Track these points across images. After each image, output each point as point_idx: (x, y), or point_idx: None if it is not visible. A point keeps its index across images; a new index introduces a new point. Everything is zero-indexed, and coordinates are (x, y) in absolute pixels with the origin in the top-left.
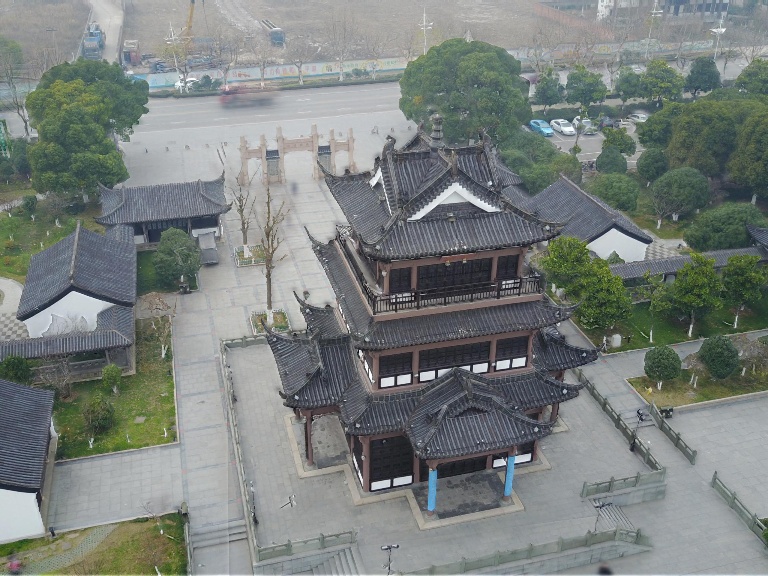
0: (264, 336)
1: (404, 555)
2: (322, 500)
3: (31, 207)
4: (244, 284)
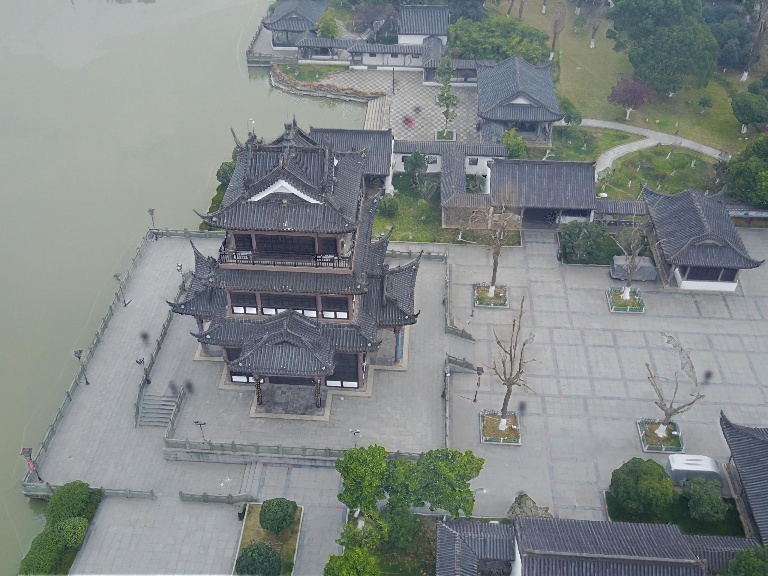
0: None
1: None
2: None
3: None
4: (570, 291)
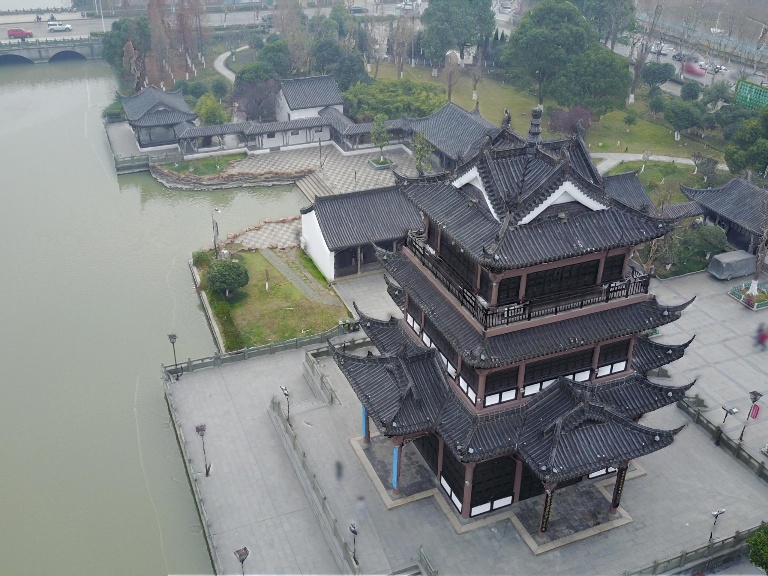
0: None
1: (320, 432)
2: None
3: (707, 168)
4: (697, 303)
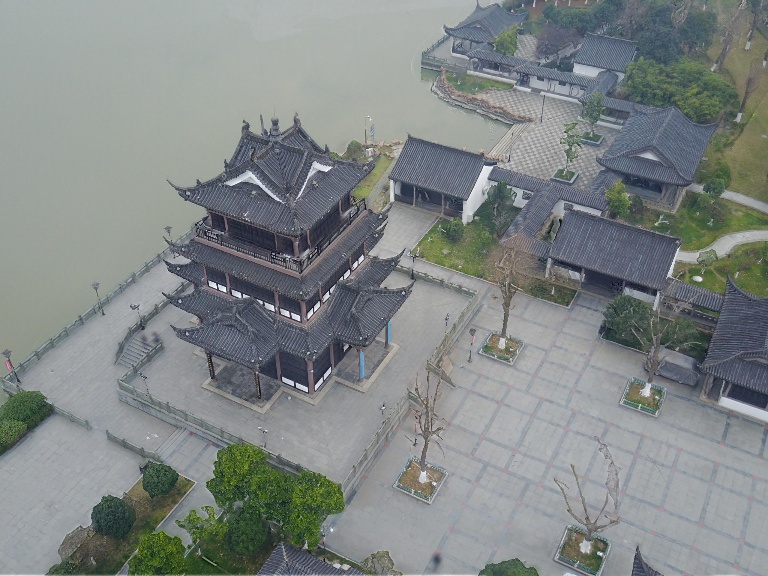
0: (464, 312)
1: None
2: None
3: None
4: (590, 368)
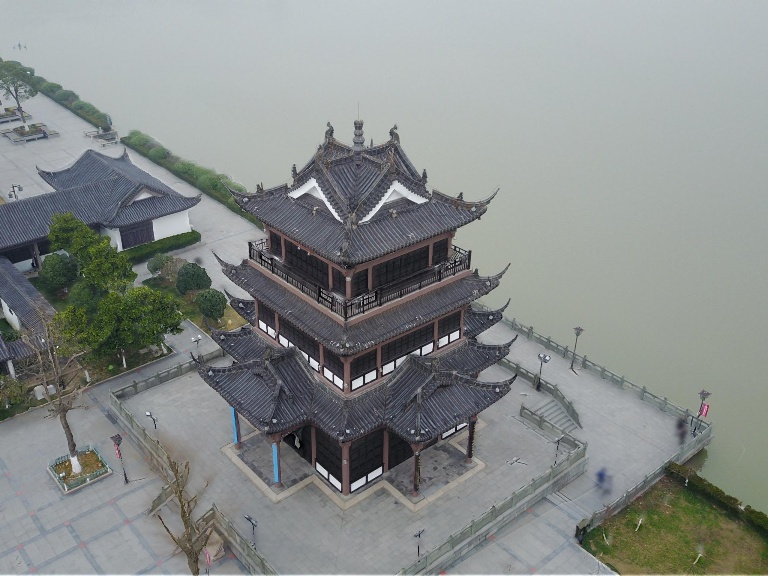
0: None
1: (511, 390)
2: (498, 445)
3: None
4: None
